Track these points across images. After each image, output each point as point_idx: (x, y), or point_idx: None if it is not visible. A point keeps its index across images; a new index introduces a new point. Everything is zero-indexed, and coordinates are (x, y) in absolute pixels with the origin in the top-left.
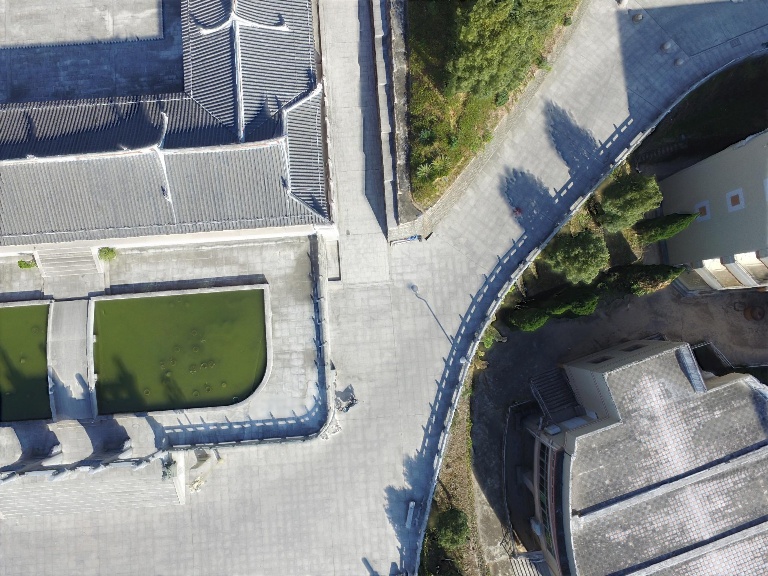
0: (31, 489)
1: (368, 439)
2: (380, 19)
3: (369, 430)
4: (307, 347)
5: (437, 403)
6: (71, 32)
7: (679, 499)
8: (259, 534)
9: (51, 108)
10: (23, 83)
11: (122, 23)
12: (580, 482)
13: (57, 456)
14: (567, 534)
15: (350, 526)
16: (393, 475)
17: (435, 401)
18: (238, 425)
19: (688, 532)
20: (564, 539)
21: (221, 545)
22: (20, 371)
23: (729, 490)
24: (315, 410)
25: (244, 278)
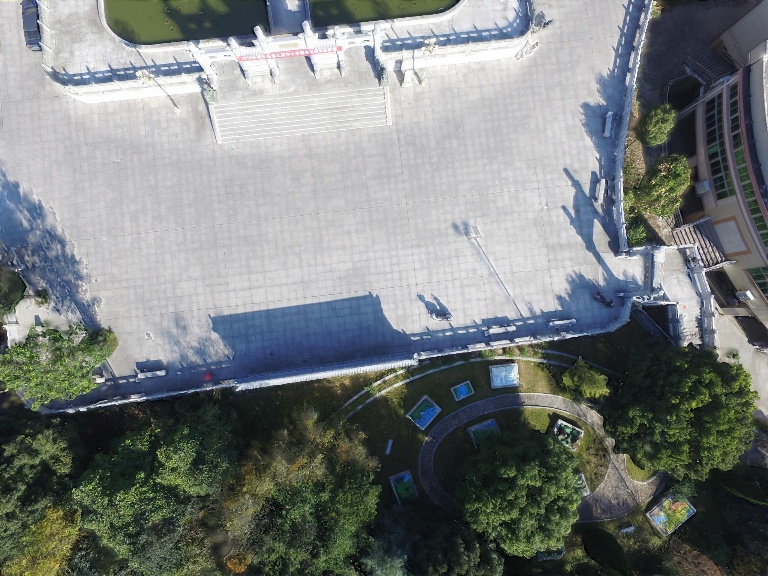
0: (251, 103)
1: (562, 60)
2: None
3: (562, 52)
4: None
5: (625, 26)
6: None
7: None
8: (464, 150)
9: None
10: None
11: None
12: (767, 93)
13: None
14: (761, 134)
15: (550, 140)
16: (588, 92)
17: (623, 24)
18: (444, 37)
19: None
20: (755, 146)
21: (428, 161)
22: None
23: None
24: (516, 21)
25: None
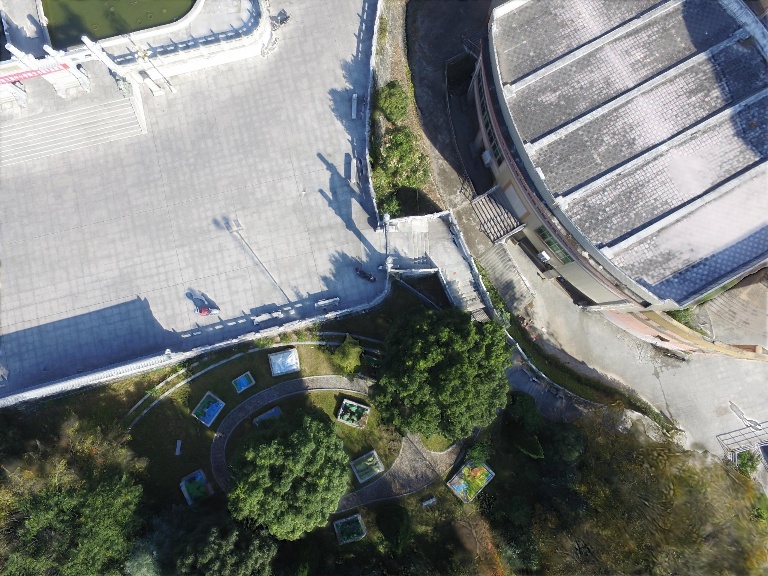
0: (2, 129)
1: (306, 52)
2: None
3: (306, 45)
4: None
5: (365, 13)
6: None
7: (600, 57)
8: (219, 148)
9: None
10: None
11: None
12: (507, 58)
13: (21, 90)
14: (501, 98)
15: (302, 128)
16: (334, 79)
17: (362, 11)
18: (183, 44)
19: (613, 84)
20: (500, 109)
21: (186, 163)
22: None
23: (645, 43)
24: (251, 21)
25: None
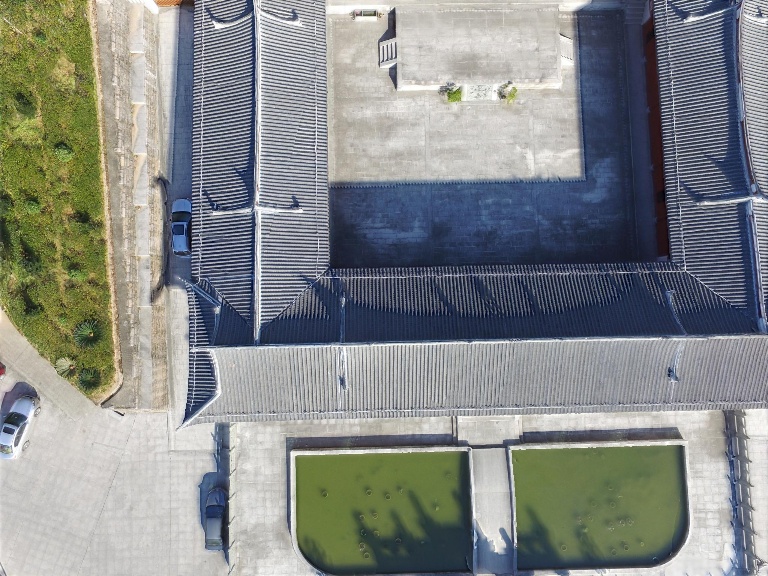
0: None
1: None
2: None
3: None
4: (723, 507)
5: None
6: (492, 169)
7: None
8: None
9: (542, 274)
10: (444, 221)
11: (544, 162)
12: None
13: None
14: None
15: None
16: None
17: None
18: None
19: None
20: None
21: None
22: (435, 519)
23: None
24: (732, 574)
25: (657, 431)
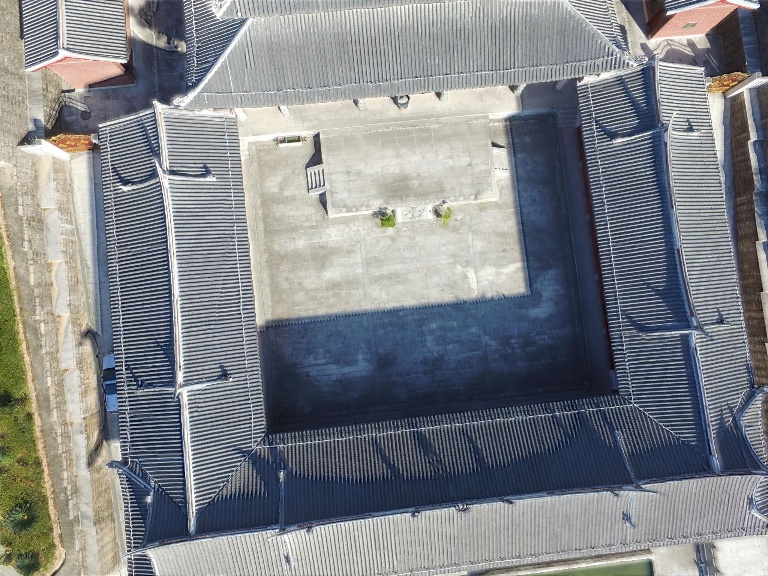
0: None
1: None
2: (767, 274)
3: None
4: None
5: None
6: (434, 292)
7: None
8: None
9: (486, 422)
10: (389, 350)
11: (486, 280)
12: None
13: None
14: None
15: None
16: None
17: None
18: None
19: None
20: None
21: None
22: None
23: None
24: None
25: None
